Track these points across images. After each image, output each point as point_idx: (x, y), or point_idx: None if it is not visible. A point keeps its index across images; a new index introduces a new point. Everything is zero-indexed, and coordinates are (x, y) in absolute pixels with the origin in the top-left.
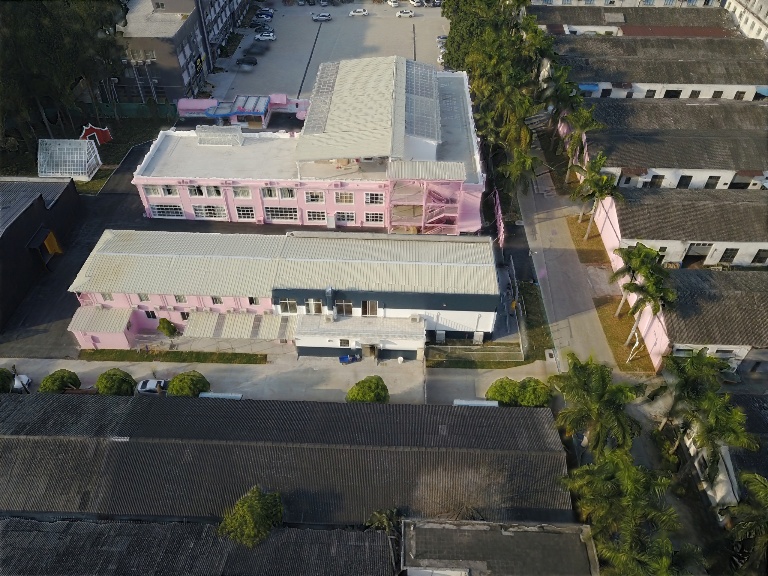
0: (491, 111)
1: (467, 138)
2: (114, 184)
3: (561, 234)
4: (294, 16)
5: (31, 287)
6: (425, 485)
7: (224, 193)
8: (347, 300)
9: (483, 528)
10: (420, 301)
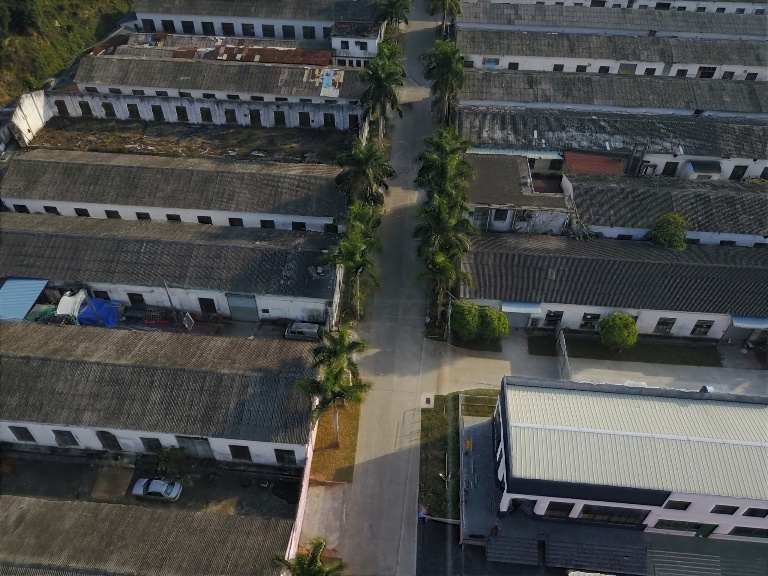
0: None
1: None
2: None
3: None
4: None
5: None
6: None
7: None
8: None
9: (525, 207)
10: None
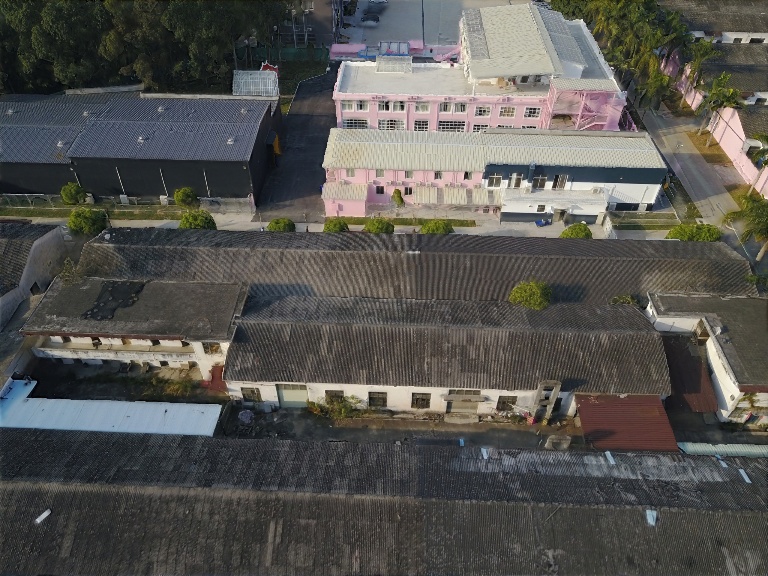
0: (618, 46)
1: (599, 68)
2: (297, 108)
3: (685, 143)
4: None
5: (266, 177)
6: (648, 281)
7: (407, 108)
8: (543, 175)
9: (707, 296)
10: (602, 175)
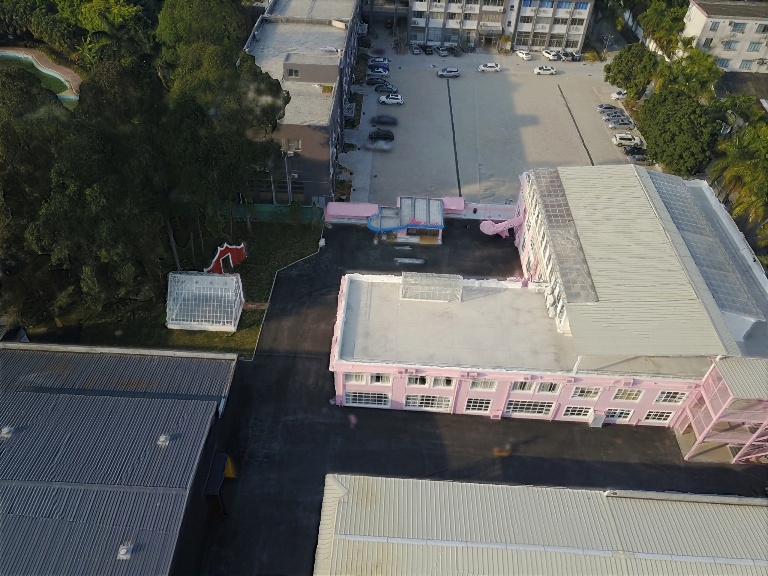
0: None
1: (762, 295)
2: (271, 338)
3: None
4: (413, 69)
5: (204, 549)
6: None
7: (458, 384)
8: None
9: None
10: None
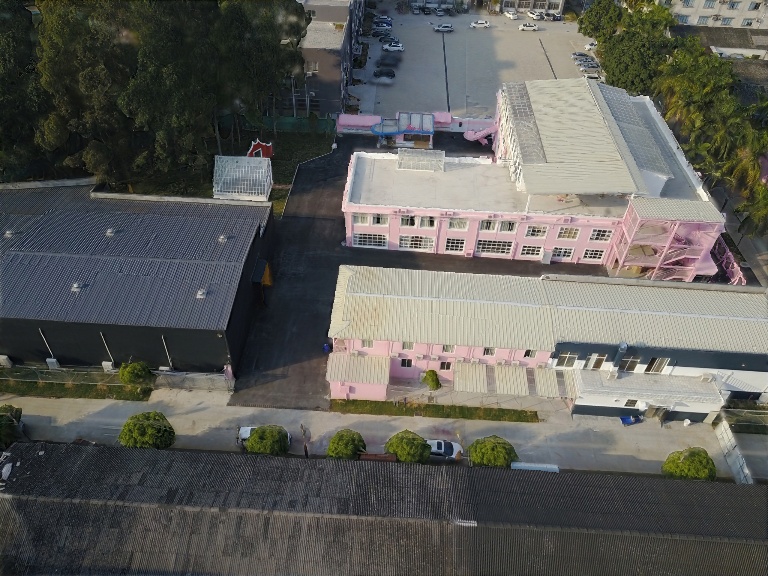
0: (704, 142)
1: (680, 171)
2: (295, 206)
3: None
4: (413, 25)
5: (251, 324)
6: None
7: (439, 224)
8: (636, 356)
9: None
10: (717, 360)
